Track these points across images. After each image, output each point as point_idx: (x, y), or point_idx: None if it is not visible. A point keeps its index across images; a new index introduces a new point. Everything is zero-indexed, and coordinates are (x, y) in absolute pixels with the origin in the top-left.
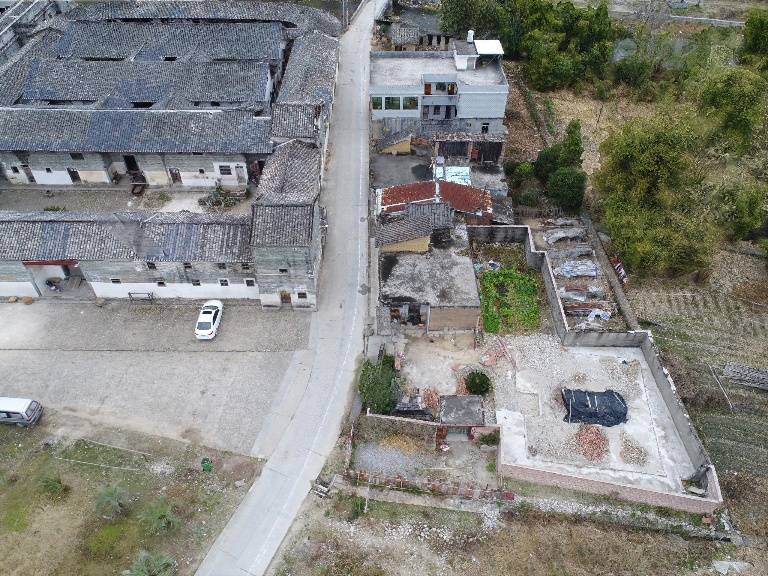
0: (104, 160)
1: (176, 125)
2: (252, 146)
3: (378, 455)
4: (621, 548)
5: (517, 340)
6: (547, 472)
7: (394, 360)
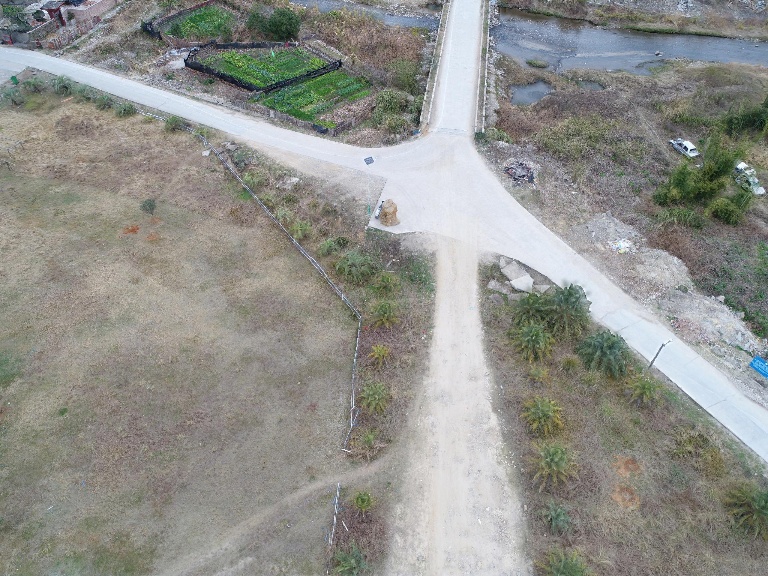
0: None
1: None
2: None
3: None
4: (136, 5)
5: None
6: (96, 4)
7: None
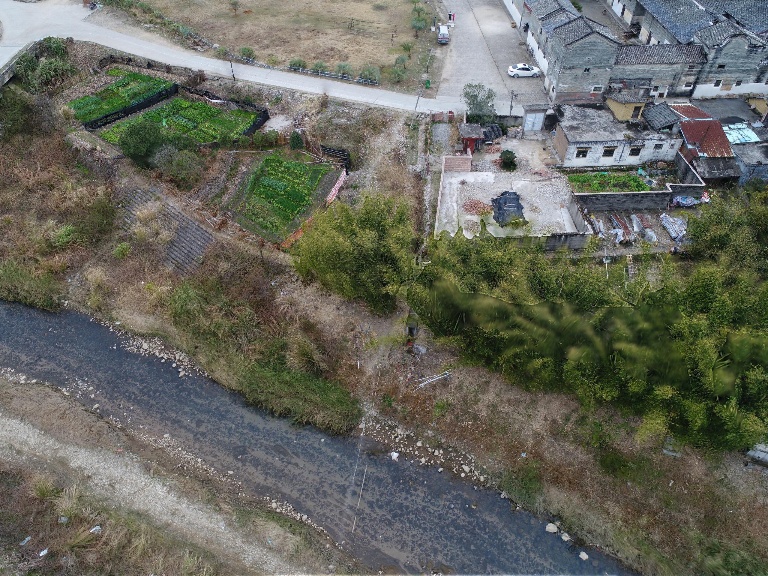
0: (637, 8)
1: (677, 4)
2: (682, 35)
3: (445, 128)
4: None
5: (563, 185)
6: None
7: (515, 127)
